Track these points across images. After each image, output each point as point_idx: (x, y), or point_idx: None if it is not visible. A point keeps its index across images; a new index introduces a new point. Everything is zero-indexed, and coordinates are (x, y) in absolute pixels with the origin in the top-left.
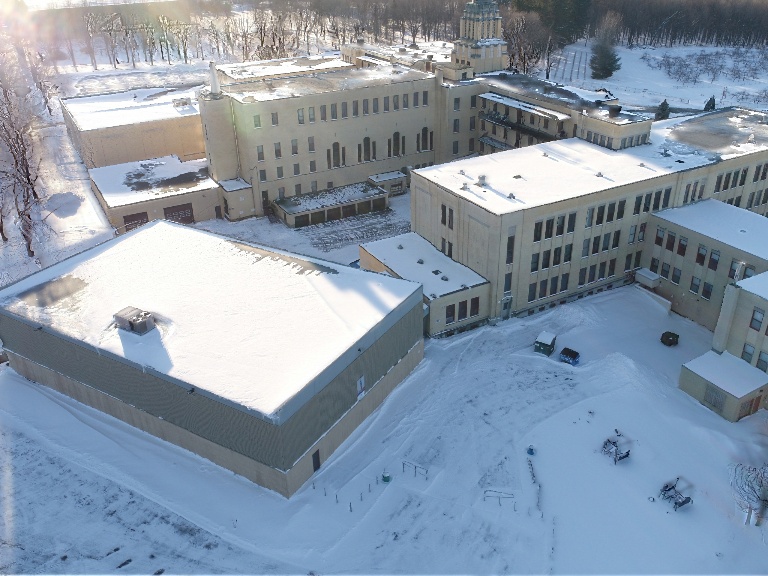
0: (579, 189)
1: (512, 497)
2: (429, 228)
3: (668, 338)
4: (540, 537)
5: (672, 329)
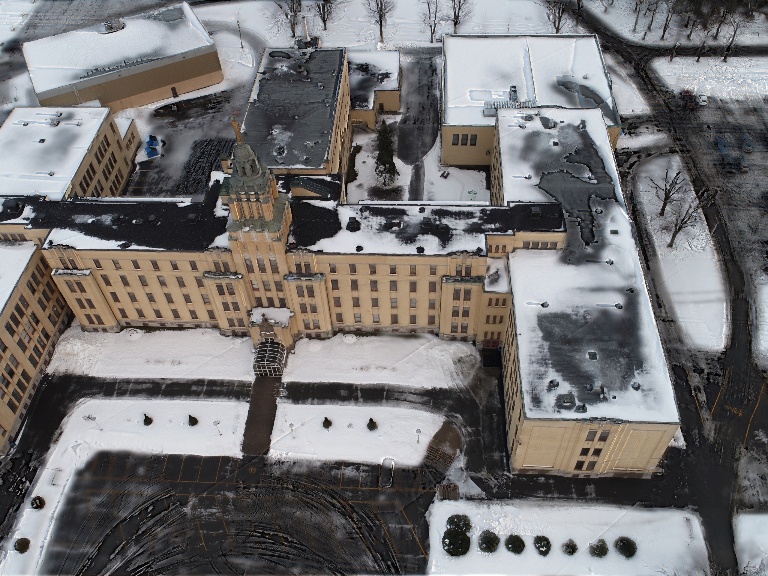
0: None
1: None
2: None
3: None
4: None
5: None
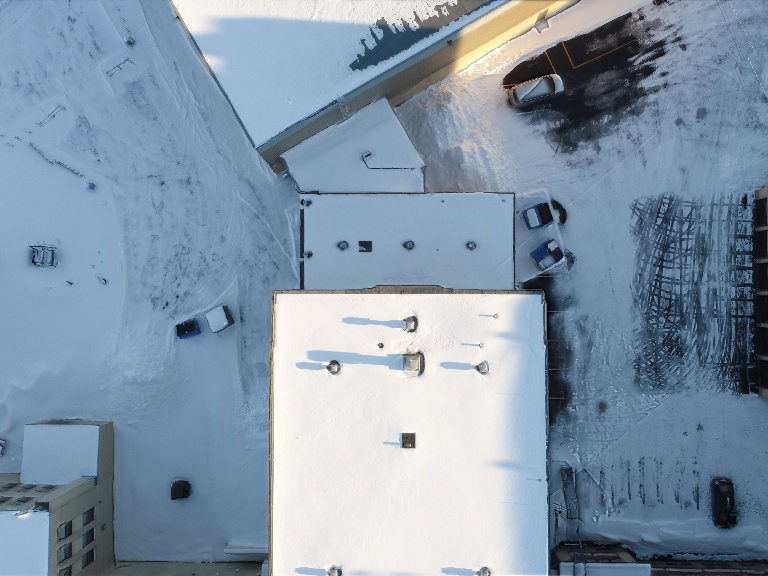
0: (301, 489)
1: (43, 123)
2: None
3: (175, 483)
4: (8, 125)
5: (200, 517)
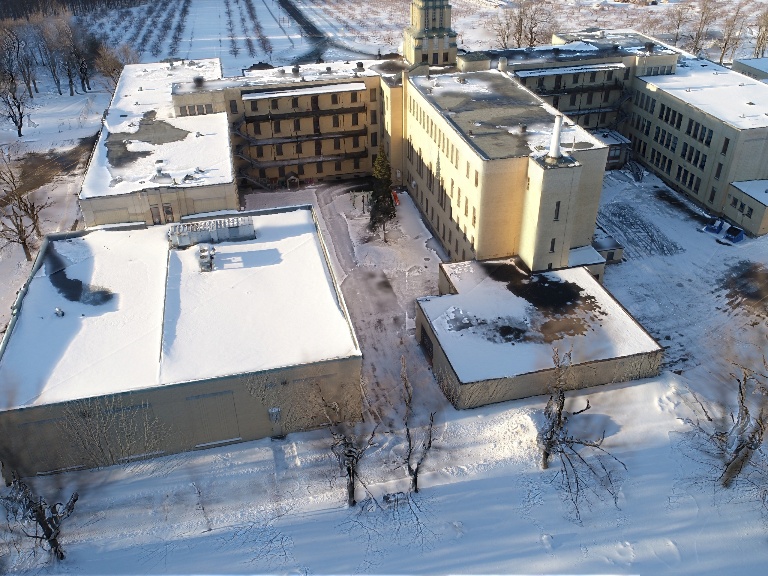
0: None
1: None
2: (757, 168)
3: None
4: None
5: None
